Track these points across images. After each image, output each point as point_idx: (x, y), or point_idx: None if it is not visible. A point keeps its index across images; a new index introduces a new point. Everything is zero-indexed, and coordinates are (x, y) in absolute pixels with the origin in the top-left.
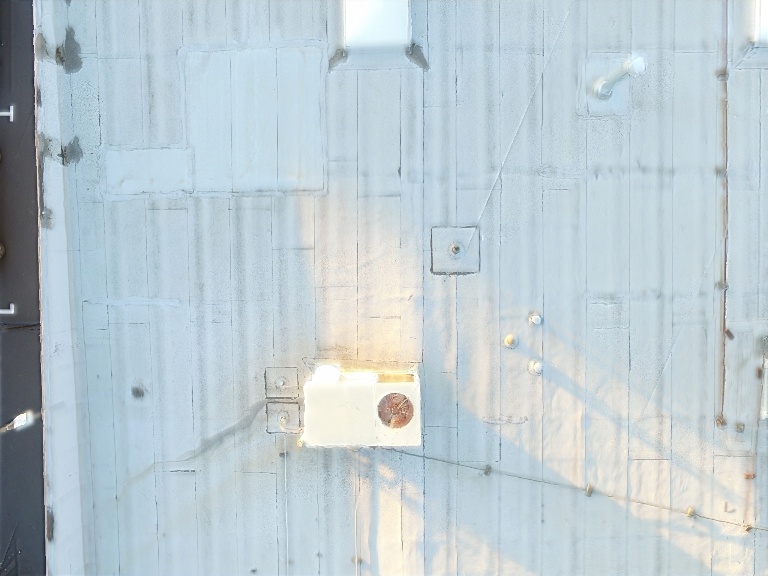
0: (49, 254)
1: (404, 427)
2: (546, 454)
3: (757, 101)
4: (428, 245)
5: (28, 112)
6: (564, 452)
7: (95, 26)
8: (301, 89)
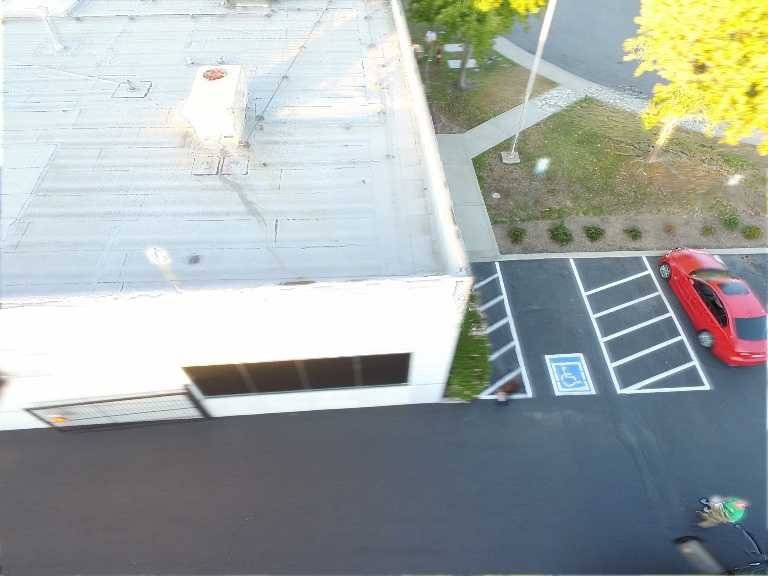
0: None
1: (227, 71)
2: (278, 60)
3: None
4: None
5: None
6: (278, 55)
7: None
8: None
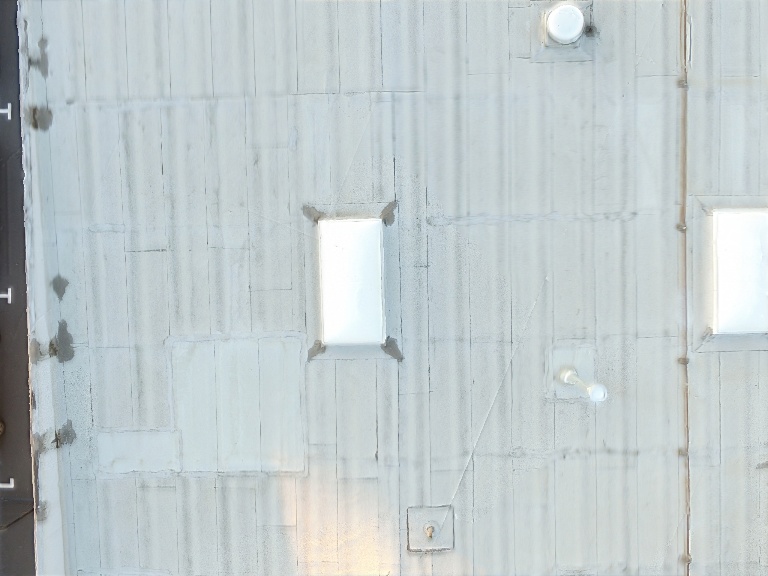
0: (45, 543)
1: None
2: None
3: (717, 382)
4: (404, 524)
5: (25, 294)
6: None
7: (86, 318)
8: (282, 377)
